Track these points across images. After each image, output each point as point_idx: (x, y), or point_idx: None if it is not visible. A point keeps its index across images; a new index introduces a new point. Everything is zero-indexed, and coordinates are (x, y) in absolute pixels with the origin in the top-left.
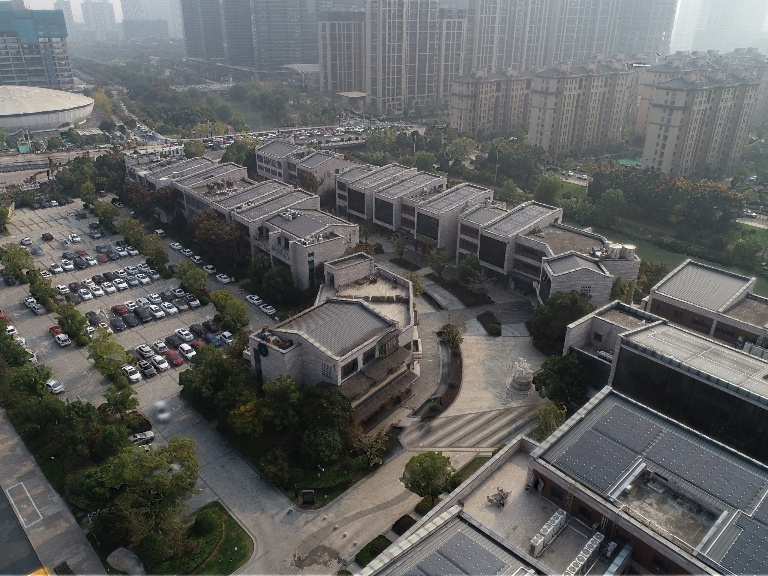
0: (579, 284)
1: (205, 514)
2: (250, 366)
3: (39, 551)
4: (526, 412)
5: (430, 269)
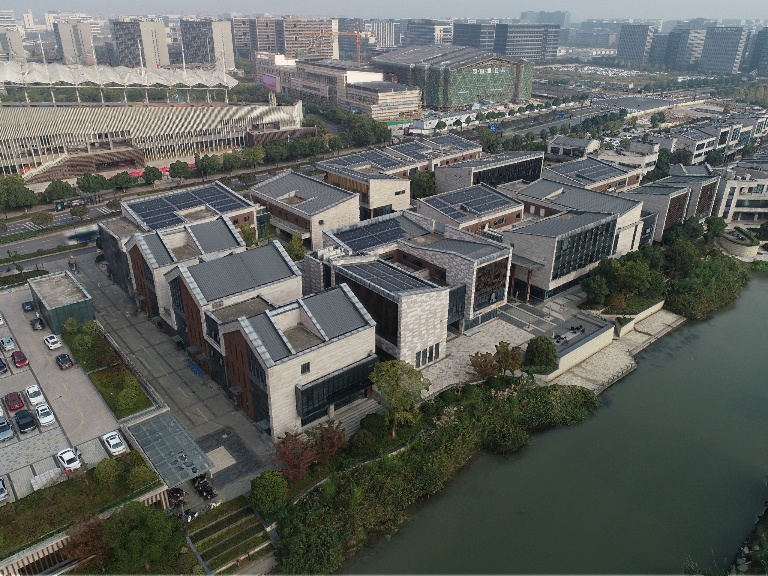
0: (676, 174)
1: None
2: None
3: None
4: None
5: None
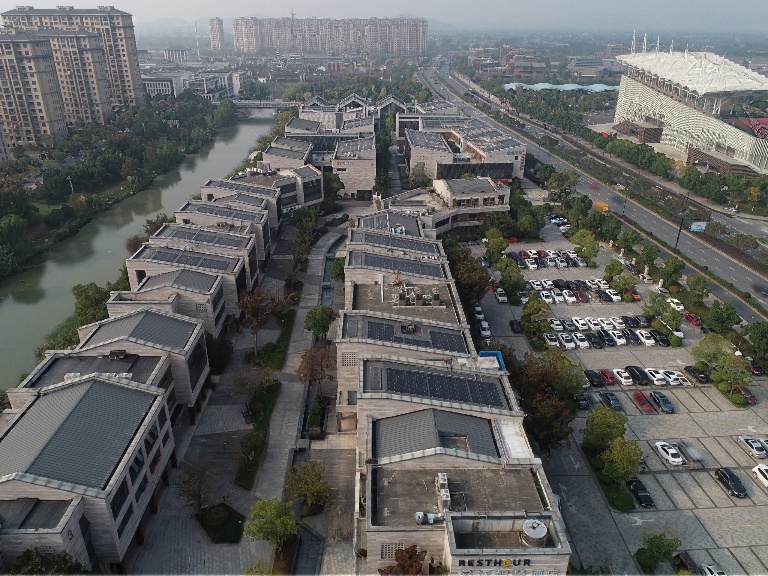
0: None
1: (547, 203)
2: None
3: None
4: None
5: (292, 257)
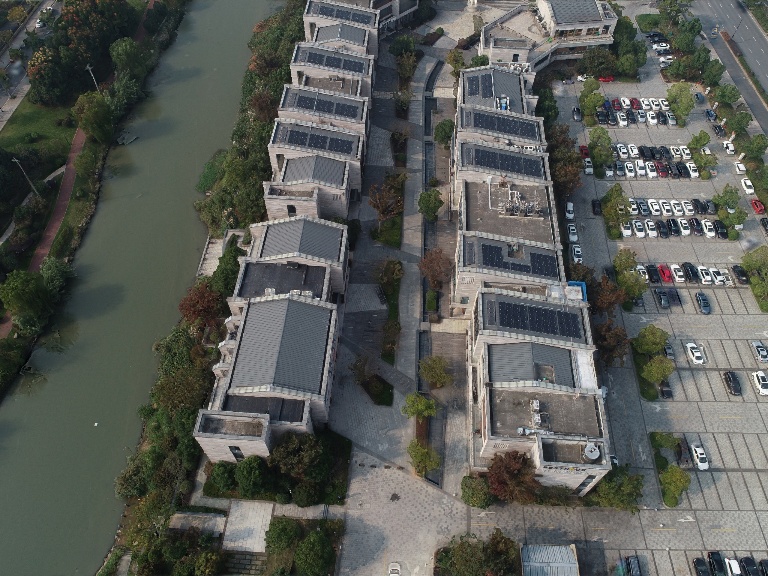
0: None
1: (653, 18)
2: (608, 48)
3: (712, 47)
4: (488, 2)
5: (392, 95)
